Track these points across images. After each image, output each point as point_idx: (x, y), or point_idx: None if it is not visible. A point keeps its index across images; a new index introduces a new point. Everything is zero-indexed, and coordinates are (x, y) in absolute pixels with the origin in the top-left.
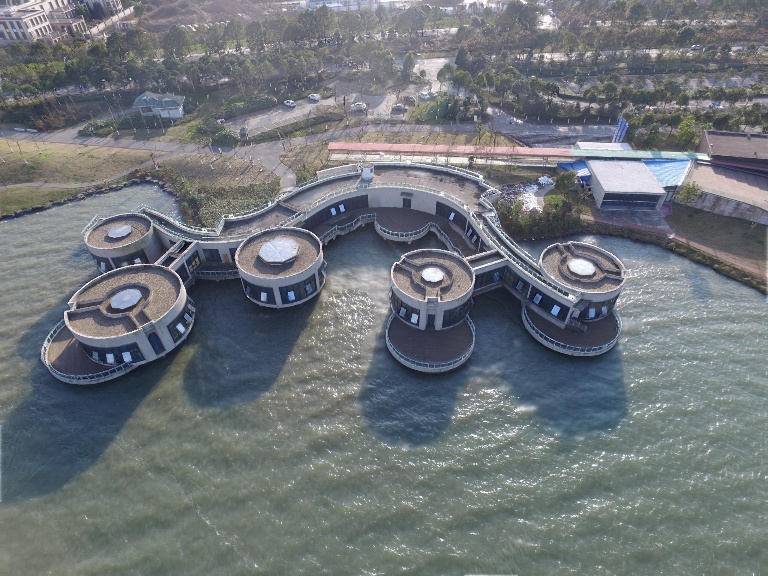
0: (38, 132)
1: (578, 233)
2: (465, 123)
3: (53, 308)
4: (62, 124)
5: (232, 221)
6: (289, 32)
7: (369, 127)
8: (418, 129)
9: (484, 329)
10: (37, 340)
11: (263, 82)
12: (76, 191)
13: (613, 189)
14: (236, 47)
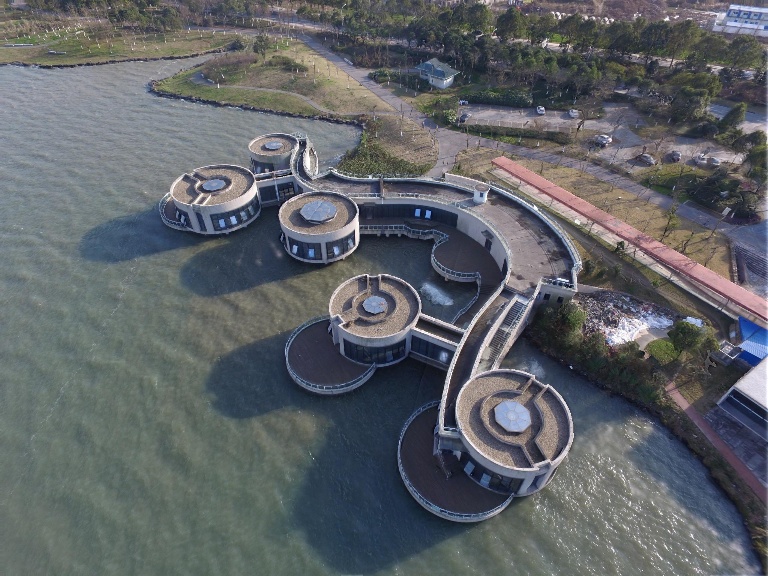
0: (352, 65)
1: (640, 405)
2: (705, 210)
3: None
4: (369, 65)
5: (335, 175)
6: (620, 40)
7: (582, 163)
8: (632, 189)
9: (384, 391)
10: None
11: (534, 81)
12: (318, 113)
13: (754, 393)
14: (562, 43)
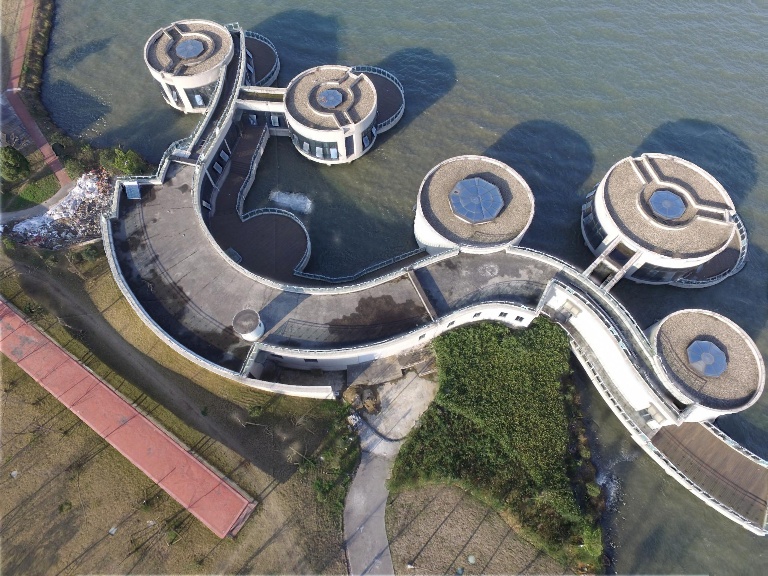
0: None
1: None
2: None
3: (762, 321)
4: None
5: None
6: None
7: None
8: None
9: None
10: (759, 263)
11: None
12: None
13: None
14: None
